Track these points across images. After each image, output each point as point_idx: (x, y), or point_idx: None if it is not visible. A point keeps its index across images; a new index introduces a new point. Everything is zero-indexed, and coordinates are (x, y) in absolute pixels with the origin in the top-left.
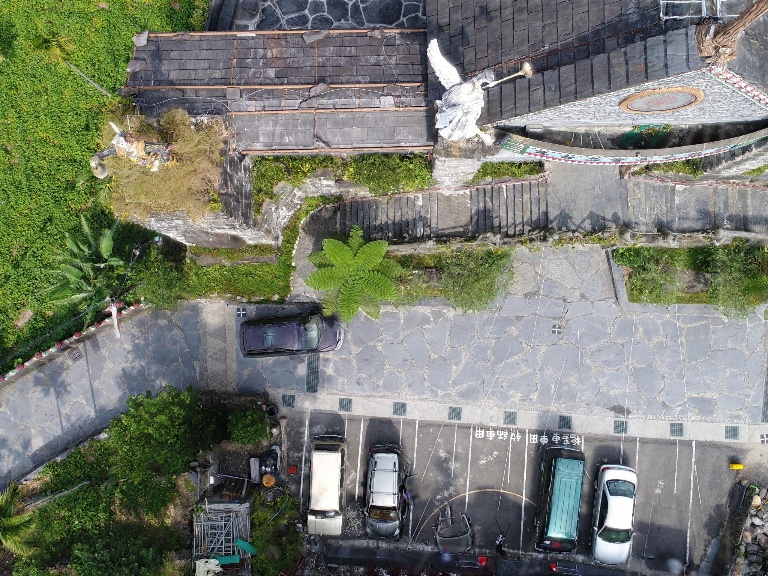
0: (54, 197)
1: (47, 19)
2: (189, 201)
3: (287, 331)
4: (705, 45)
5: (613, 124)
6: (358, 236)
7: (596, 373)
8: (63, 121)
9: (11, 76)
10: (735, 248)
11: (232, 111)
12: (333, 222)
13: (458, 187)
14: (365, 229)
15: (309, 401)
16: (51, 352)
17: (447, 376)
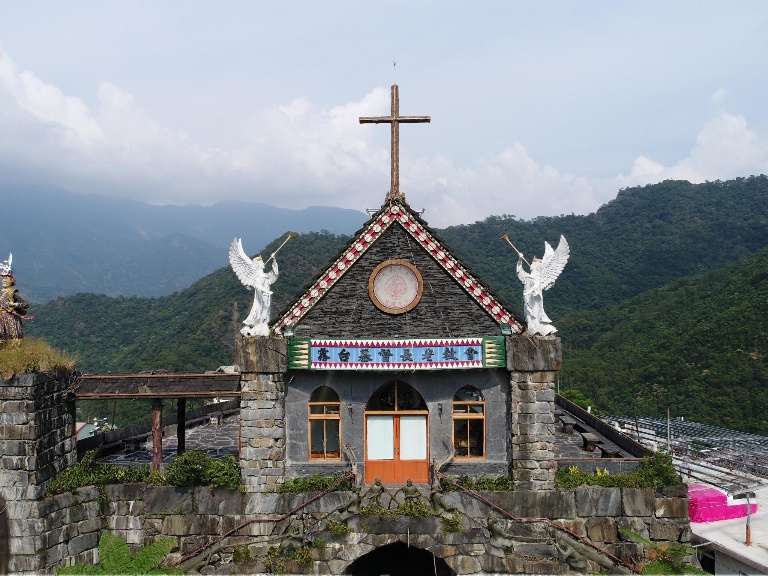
0: None
1: None
2: None
3: None
4: None
5: None
6: None
7: None
8: None
9: None
10: None
11: None
12: None
13: (270, 519)
14: None
15: None
16: None
17: None
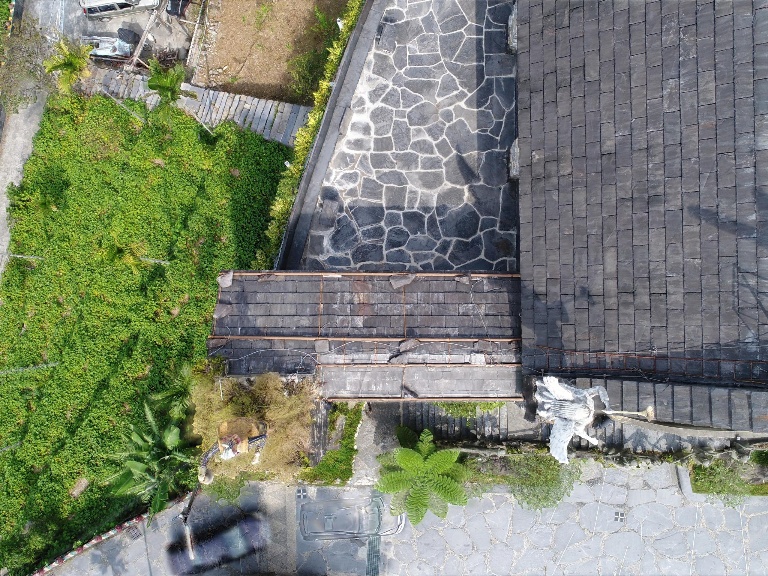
0: (109, 358)
1: (100, 169)
2: (280, 465)
3: None
4: None
5: None
6: (428, 441)
7: (658, 562)
8: (118, 279)
9: (64, 227)
10: None
11: (320, 363)
12: (396, 406)
13: None
14: (430, 418)
15: None
16: (111, 535)
17: (509, 562)
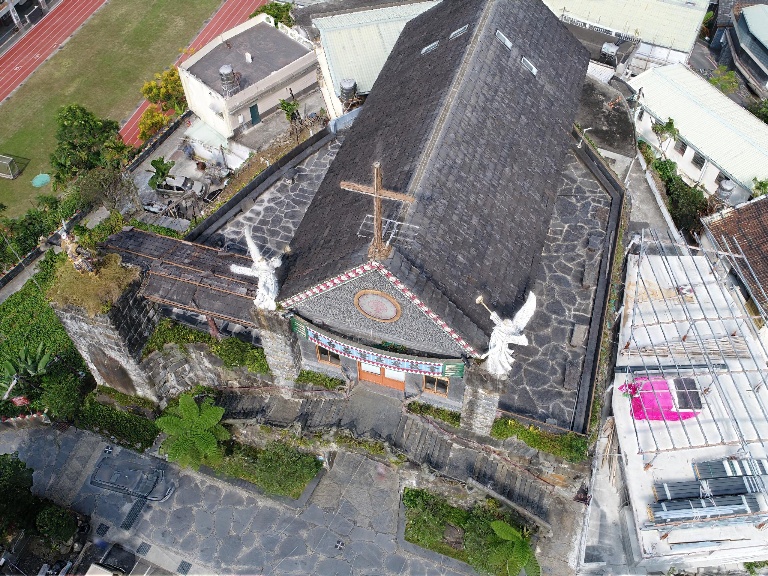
0: None
1: None
2: (92, 301)
3: (133, 475)
4: (370, 248)
5: (369, 335)
6: (209, 402)
7: None
8: None
9: None
10: (490, 509)
11: (151, 271)
12: None
13: (291, 390)
14: (225, 414)
15: (118, 535)
16: None
17: (235, 553)
